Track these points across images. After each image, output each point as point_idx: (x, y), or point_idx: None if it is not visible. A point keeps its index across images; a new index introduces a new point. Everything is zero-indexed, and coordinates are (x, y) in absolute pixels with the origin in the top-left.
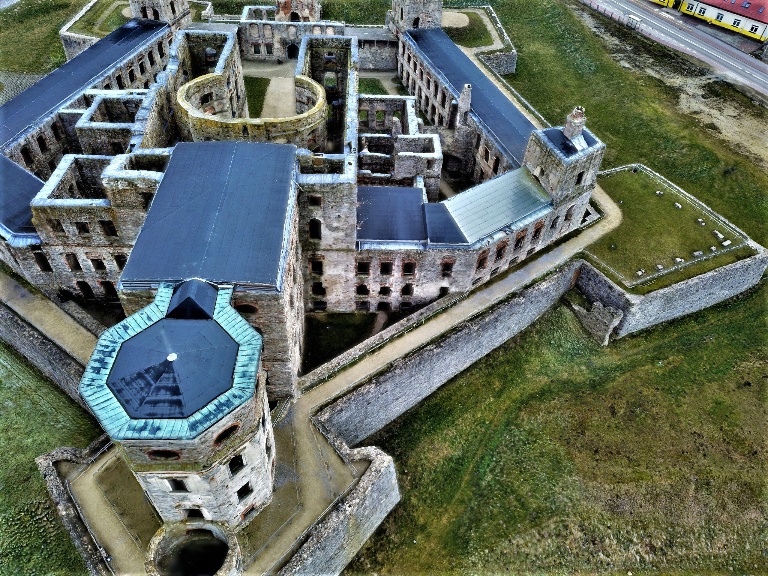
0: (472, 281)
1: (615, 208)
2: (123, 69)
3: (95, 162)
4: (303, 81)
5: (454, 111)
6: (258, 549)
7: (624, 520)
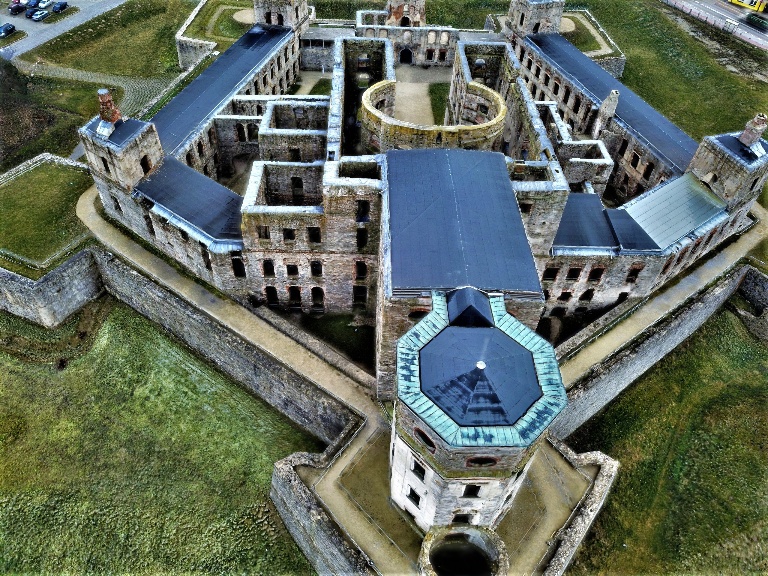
0: (652, 286)
1: (766, 213)
2: (260, 74)
3: (283, 169)
4: (477, 88)
5: (593, 116)
6: (511, 553)
7: None
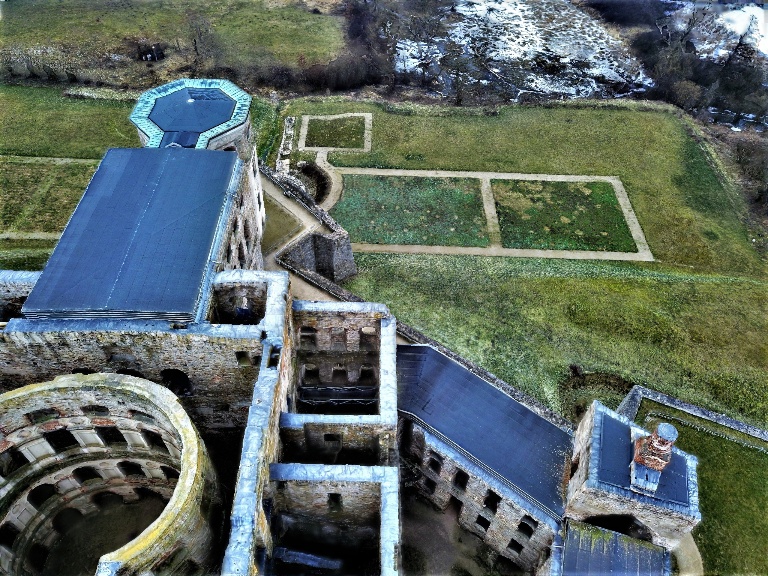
0: None
1: None
2: None
3: None
4: None
5: None
6: None
7: None
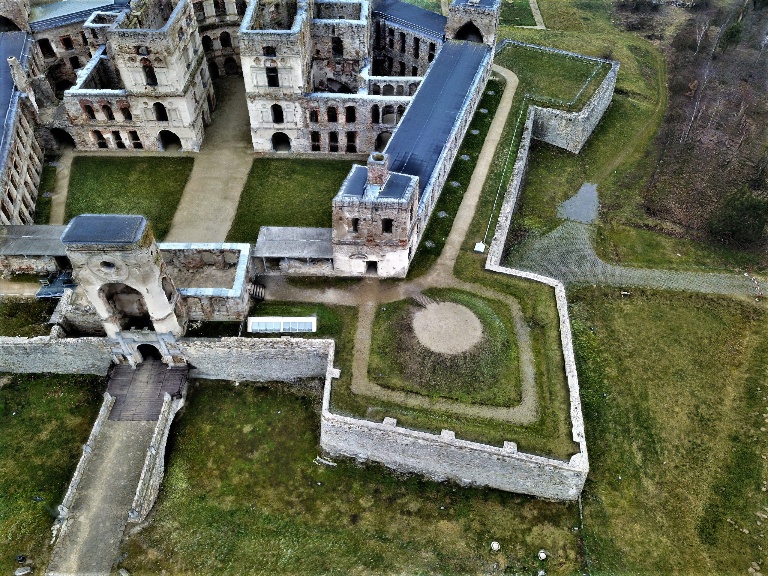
0: None
1: None
2: None
3: None
4: None
5: None
6: None
7: None
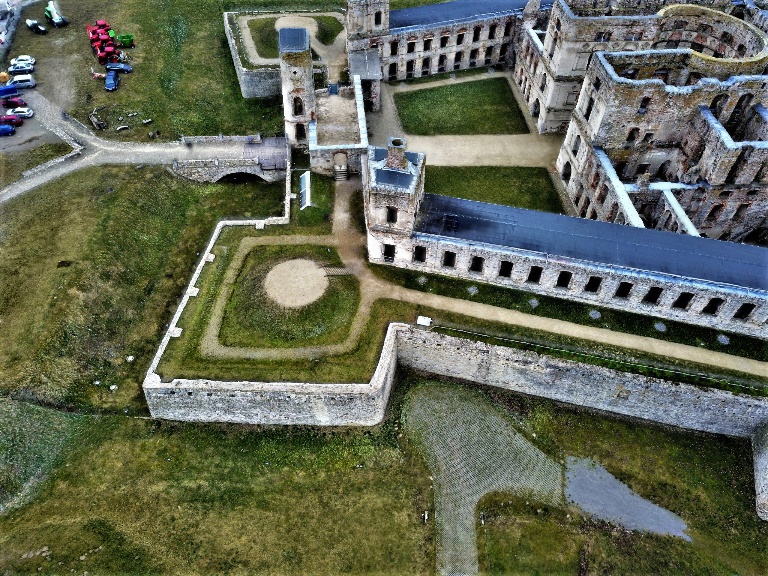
0: None
1: None
2: None
3: None
4: None
5: (521, 23)
6: None
7: None
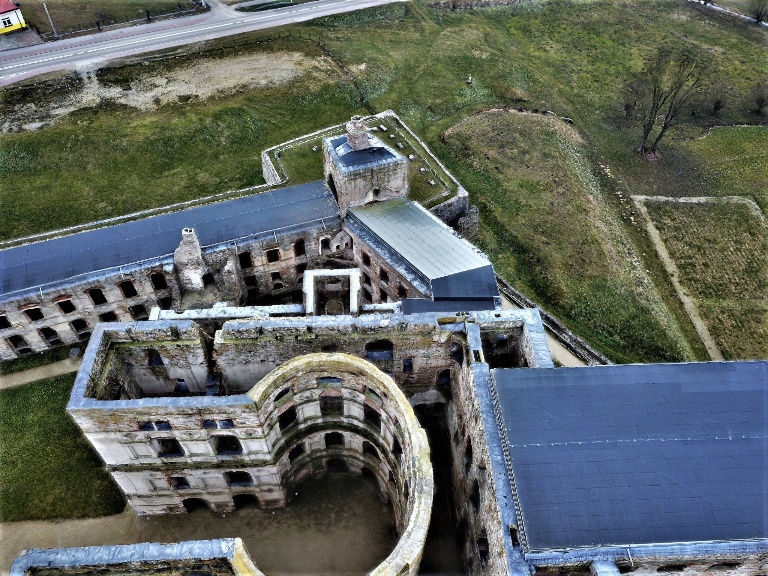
0: None
1: None
2: None
3: None
4: (266, 391)
5: (176, 275)
6: None
7: (622, 261)
